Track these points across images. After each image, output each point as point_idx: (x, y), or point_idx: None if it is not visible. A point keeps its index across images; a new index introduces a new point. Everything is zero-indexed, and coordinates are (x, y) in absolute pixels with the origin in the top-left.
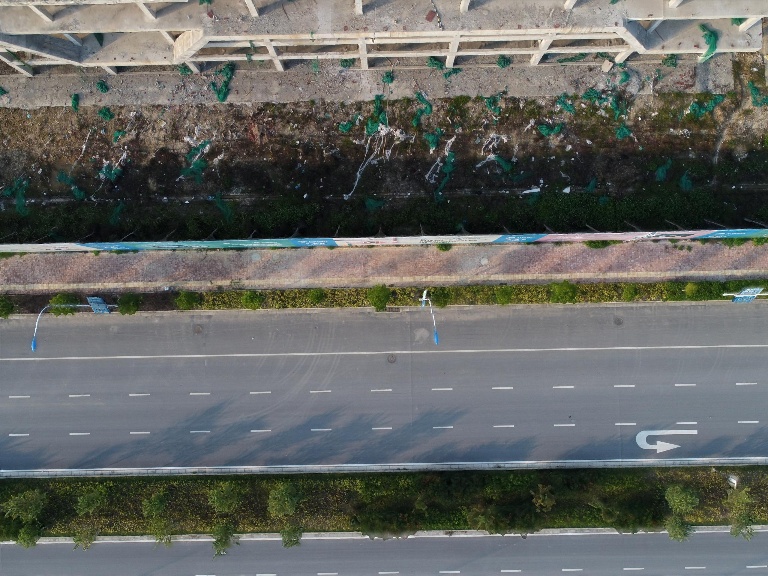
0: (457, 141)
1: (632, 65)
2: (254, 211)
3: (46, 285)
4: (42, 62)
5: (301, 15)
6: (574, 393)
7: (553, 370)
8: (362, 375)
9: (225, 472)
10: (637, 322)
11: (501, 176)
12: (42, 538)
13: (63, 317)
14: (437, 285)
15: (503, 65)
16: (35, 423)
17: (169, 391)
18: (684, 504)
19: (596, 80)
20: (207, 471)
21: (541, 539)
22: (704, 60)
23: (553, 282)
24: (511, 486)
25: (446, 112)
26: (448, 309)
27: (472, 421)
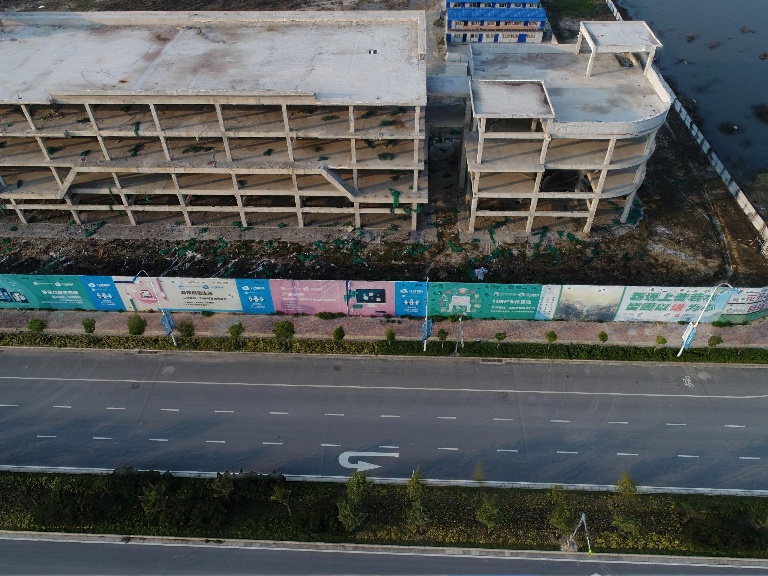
0: (239, 261)
1: (368, 230)
2: None
3: None
4: None
5: (135, 161)
6: (288, 418)
7: (273, 400)
8: (105, 396)
9: None
10: (353, 369)
11: None
12: None
13: None
14: (194, 337)
15: (281, 227)
16: None
17: None
18: None
19: (342, 235)
20: None
21: (222, 551)
22: (415, 227)
23: None
24: (204, 490)
25: (236, 246)
26: (197, 354)
27: (188, 436)
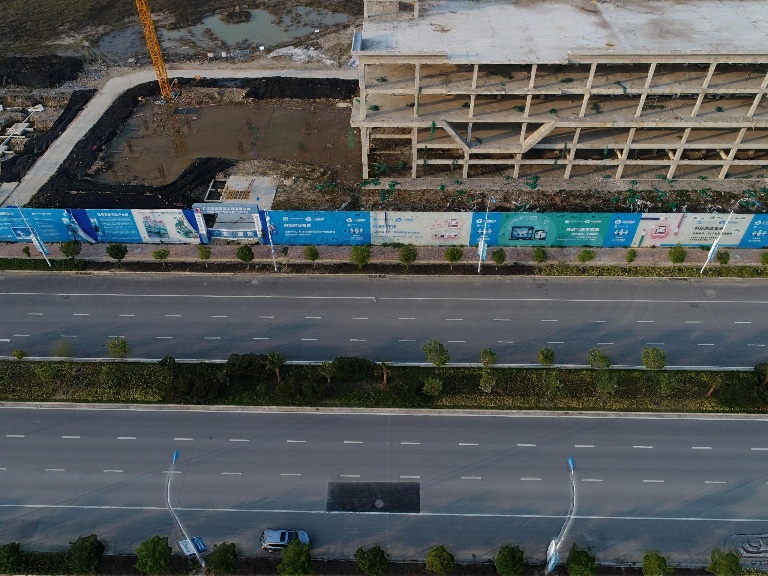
0: None
1: None
2: None
3: (427, 261)
4: (434, 161)
5: (606, 117)
6: None
7: None
8: (675, 313)
9: None
10: None
11: None
12: (428, 411)
13: (438, 278)
14: None
15: (703, 179)
16: (420, 334)
17: (525, 318)
18: None
19: (764, 185)
20: (568, 367)
21: None
22: None
23: None
24: None
25: (676, 195)
26: (723, 280)
27: None
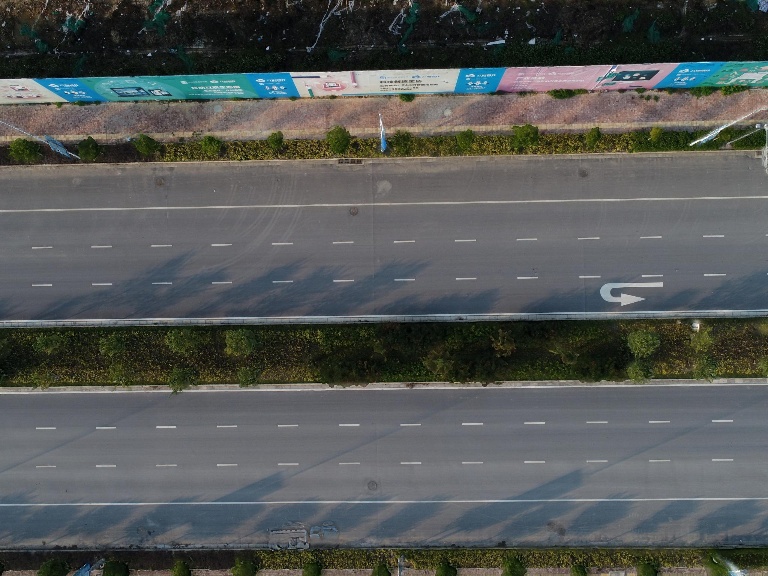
0: None
1: None
2: (216, 61)
3: (9, 137)
4: None
5: None
6: (538, 245)
7: (517, 222)
8: (324, 227)
9: (186, 323)
10: (602, 174)
11: (465, 26)
12: (5, 388)
13: (26, 170)
14: None
15: None
16: None
17: (131, 243)
18: (645, 345)
19: None
20: (168, 322)
21: (503, 392)
22: None
23: (515, 127)
24: (473, 337)
25: None
26: (411, 161)
27: (434, 273)
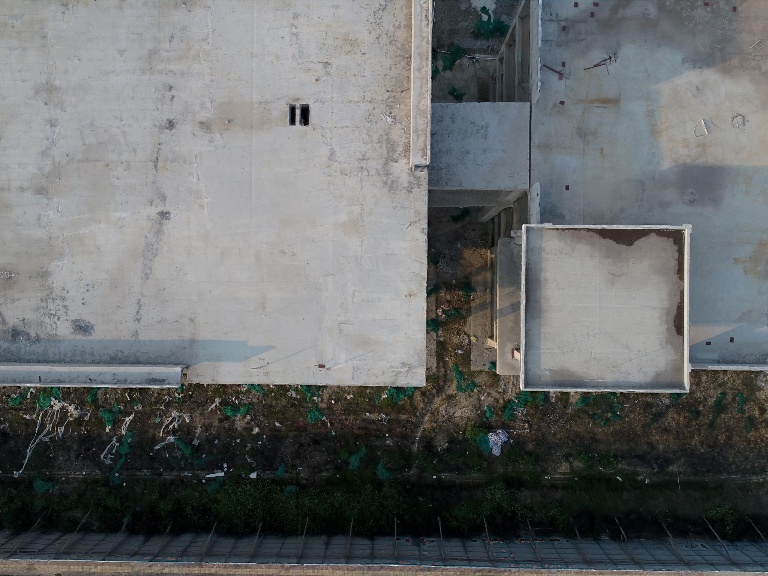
0: (136, 419)
1: None
2: None
3: None
4: None
5: None
6: None
7: None
8: None
9: None
10: None
11: (180, 460)
12: None
13: None
14: None
15: None
16: None
17: None
18: None
19: None
20: None
21: None
22: None
23: None
24: None
25: None
26: None
27: None
